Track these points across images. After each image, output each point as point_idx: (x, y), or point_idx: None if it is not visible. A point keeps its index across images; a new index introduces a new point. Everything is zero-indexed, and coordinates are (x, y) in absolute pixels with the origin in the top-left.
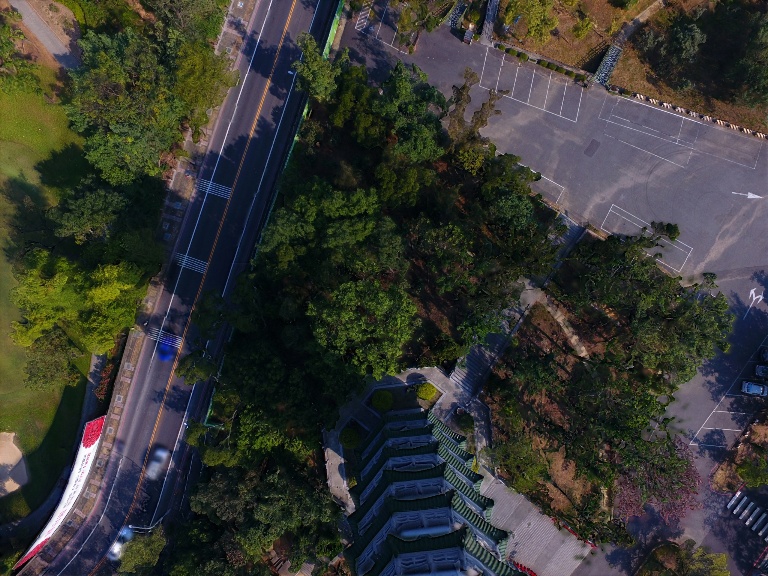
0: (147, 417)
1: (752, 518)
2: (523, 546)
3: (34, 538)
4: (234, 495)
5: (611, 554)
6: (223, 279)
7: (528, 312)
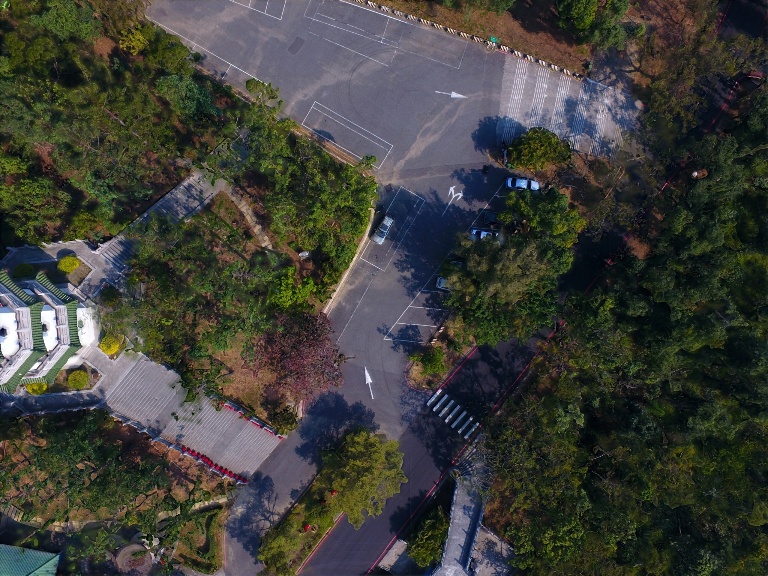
0: None
1: (452, 416)
2: (192, 430)
3: None
4: None
5: (301, 447)
6: None
7: (209, 200)
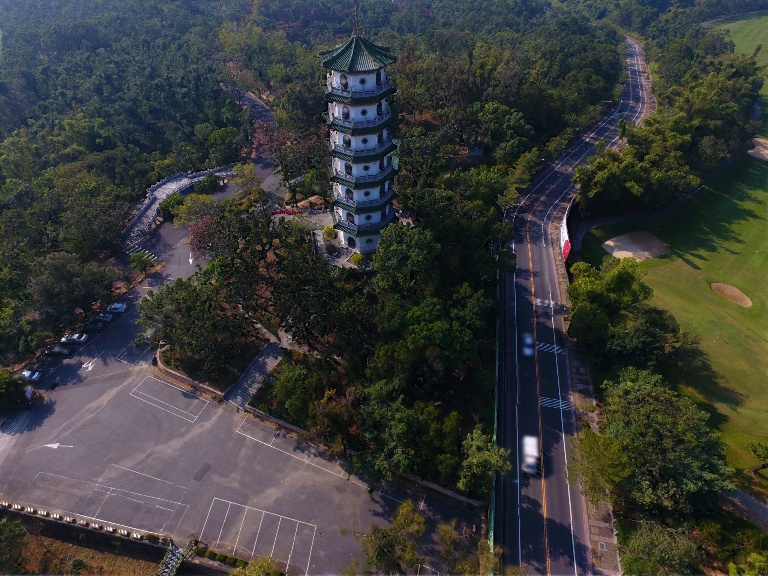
0: (539, 265)
1: None
2: None
3: (579, 219)
4: None
5: None
6: (520, 341)
7: None
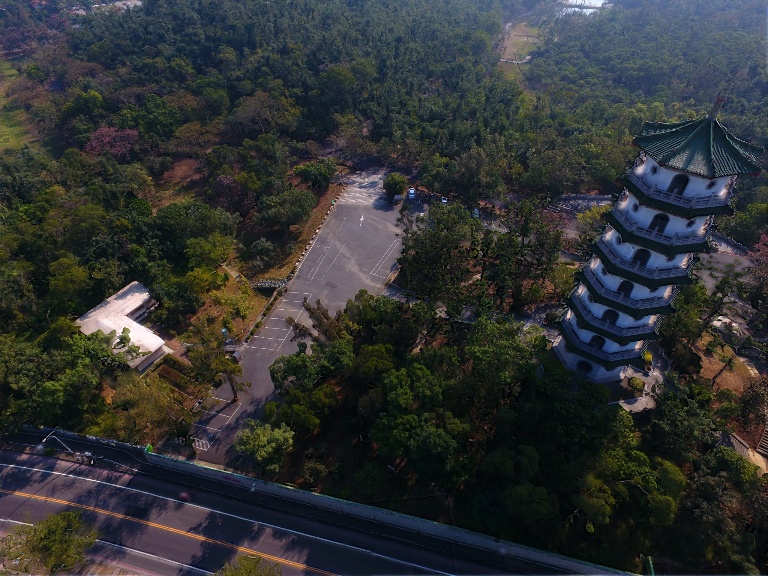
0: None
1: None
2: None
3: None
4: (707, 494)
5: None
6: None
7: None
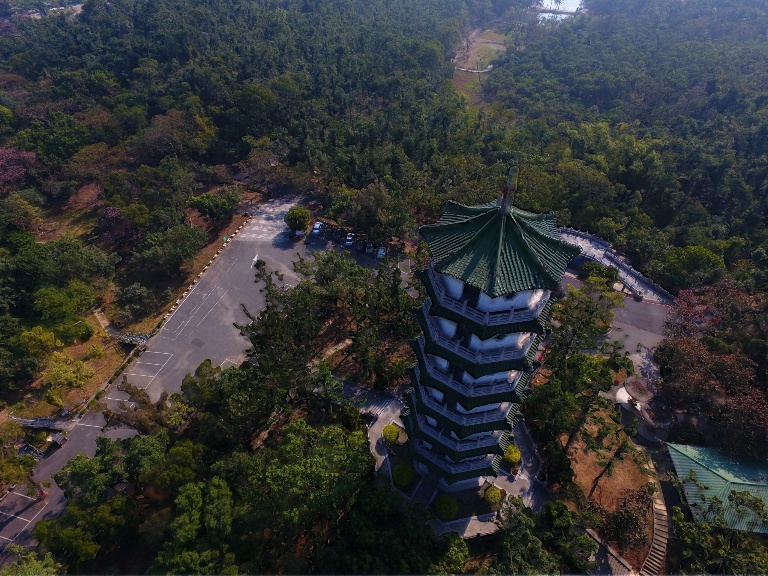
0: None
1: None
2: None
3: None
4: None
5: None
6: None
7: None
